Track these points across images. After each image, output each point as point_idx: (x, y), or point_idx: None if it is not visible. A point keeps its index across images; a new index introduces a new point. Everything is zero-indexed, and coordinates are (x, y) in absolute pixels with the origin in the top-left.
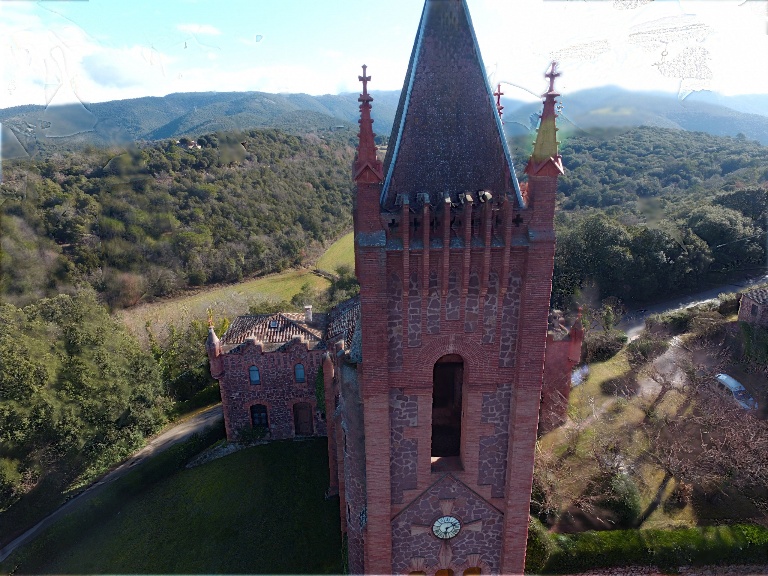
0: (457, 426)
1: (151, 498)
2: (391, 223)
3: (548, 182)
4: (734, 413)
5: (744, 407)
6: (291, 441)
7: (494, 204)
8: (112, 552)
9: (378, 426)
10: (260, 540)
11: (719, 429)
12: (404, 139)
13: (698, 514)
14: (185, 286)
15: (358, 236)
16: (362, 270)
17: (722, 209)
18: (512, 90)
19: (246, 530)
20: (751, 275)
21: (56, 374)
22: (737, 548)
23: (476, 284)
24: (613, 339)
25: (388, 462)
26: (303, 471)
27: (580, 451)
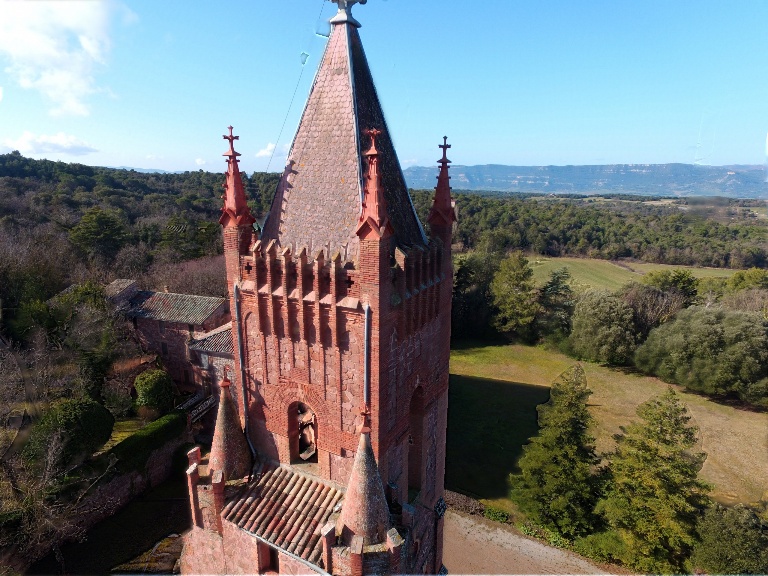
0: None
1: None
2: None
3: None
4: None
5: None
6: None
7: None
8: None
9: None
10: None
11: None
12: None
13: None
14: None
15: None
16: None
17: None
18: None
19: None
20: None
21: None
22: None
23: None
24: None
25: None
26: None
27: None
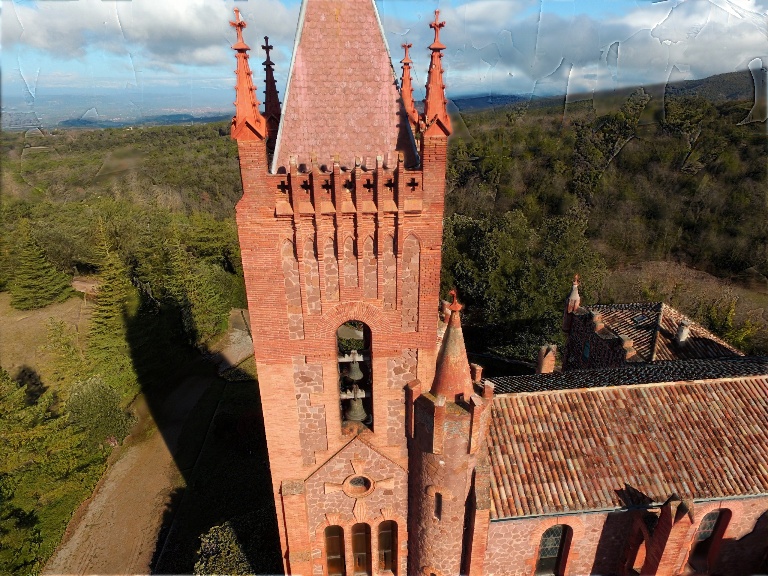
0: None
1: None
2: None
3: None
4: None
5: None
6: None
7: None
8: None
9: None
10: None
11: None
12: None
13: None
14: None
15: None
16: None
17: None
18: None
19: None
20: None
21: (515, 269)
22: None
23: None
24: None
25: None
26: None
27: None
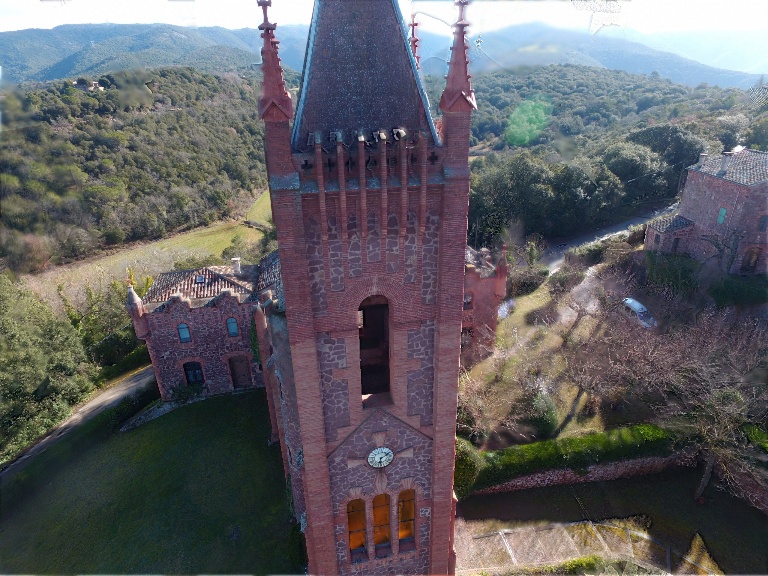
0: (388, 364)
1: (85, 465)
2: (304, 164)
3: (461, 118)
4: (636, 332)
5: (646, 326)
6: (230, 395)
7: (409, 142)
8: (48, 522)
9: (307, 370)
10: (205, 491)
11: (624, 347)
12: (312, 73)
13: (605, 421)
14: (99, 245)
15: (270, 179)
16: (277, 215)
17: (633, 145)
18: (429, 21)
19: (190, 484)
20: (656, 207)
21: None
22: (635, 446)
23: (395, 224)
24: (536, 273)
25: (320, 404)
26: (244, 422)
27: (506, 377)
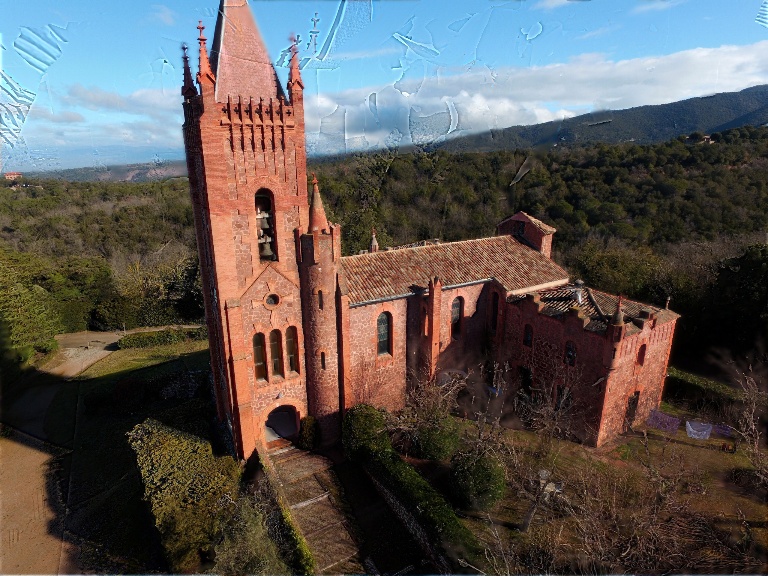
0: None
1: None
2: None
3: None
4: None
5: None
6: None
7: None
8: None
9: None
10: None
11: None
12: None
13: None
14: None
15: None
16: None
17: None
18: None
19: None
20: None
21: None
22: None
23: None
24: None
25: (198, 242)
26: None
27: (550, 462)
